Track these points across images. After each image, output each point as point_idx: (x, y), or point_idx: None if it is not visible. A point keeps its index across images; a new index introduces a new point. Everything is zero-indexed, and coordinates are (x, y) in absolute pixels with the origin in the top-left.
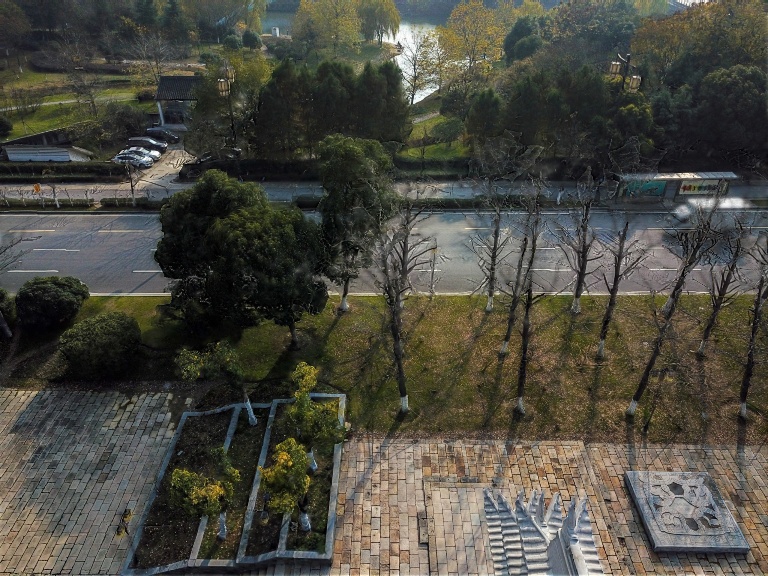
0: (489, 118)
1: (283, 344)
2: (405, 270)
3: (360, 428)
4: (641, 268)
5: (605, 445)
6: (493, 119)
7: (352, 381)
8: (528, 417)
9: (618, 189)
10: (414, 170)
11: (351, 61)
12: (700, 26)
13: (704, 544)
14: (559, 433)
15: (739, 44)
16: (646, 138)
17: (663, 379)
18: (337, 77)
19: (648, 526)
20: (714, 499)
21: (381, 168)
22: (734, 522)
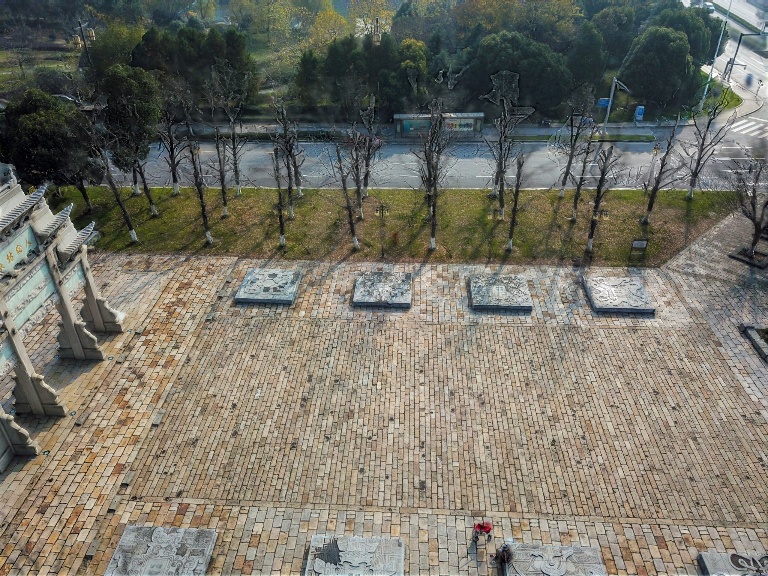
0: (308, 73)
1: (82, 211)
2: (174, 164)
3: (100, 249)
4: (374, 175)
5: (252, 259)
6: (310, 74)
7: (113, 229)
8: (213, 246)
9: (396, 126)
10: (254, 115)
11: (201, 28)
12: (500, 3)
13: (265, 298)
14: (226, 253)
15: (524, 16)
16: (419, 86)
17: (281, 212)
18: (186, 40)
19: (238, 290)
20: (292, 280)
21: (143, 87)
22: (293, 290)
